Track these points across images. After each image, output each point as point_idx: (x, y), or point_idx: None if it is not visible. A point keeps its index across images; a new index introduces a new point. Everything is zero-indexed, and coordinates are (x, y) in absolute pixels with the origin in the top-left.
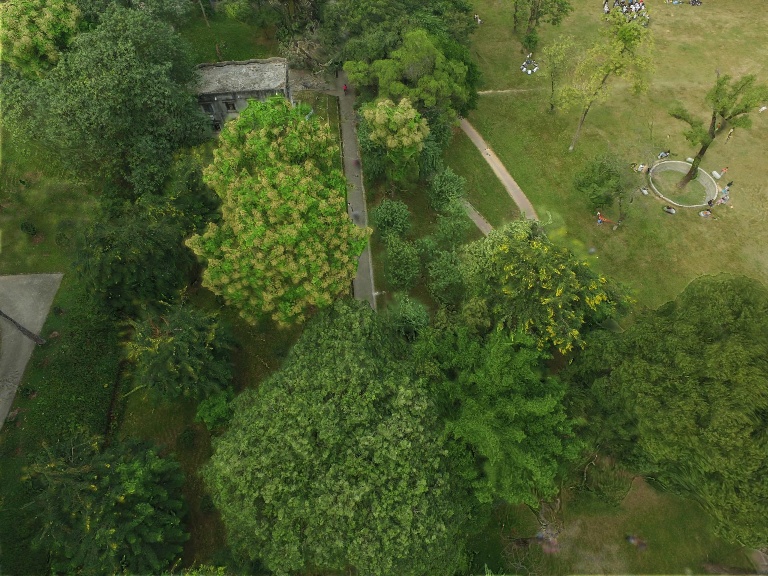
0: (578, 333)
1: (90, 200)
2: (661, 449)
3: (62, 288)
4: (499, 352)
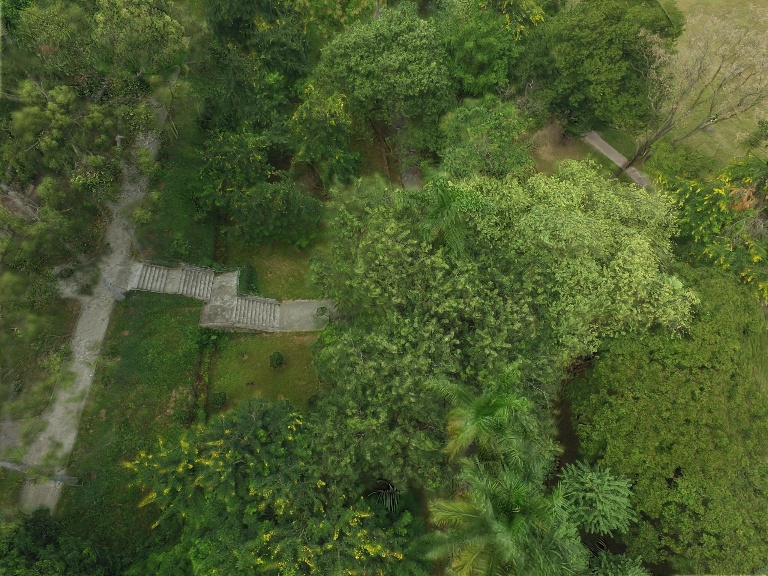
0: (524, 27)
1: (199, 2)
2: (562, 47)
3: (192, 42)
4: (475, 8)
